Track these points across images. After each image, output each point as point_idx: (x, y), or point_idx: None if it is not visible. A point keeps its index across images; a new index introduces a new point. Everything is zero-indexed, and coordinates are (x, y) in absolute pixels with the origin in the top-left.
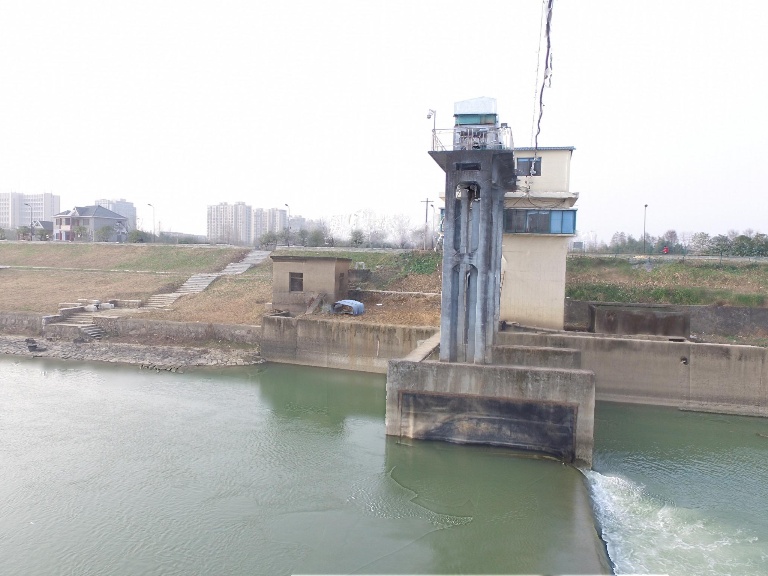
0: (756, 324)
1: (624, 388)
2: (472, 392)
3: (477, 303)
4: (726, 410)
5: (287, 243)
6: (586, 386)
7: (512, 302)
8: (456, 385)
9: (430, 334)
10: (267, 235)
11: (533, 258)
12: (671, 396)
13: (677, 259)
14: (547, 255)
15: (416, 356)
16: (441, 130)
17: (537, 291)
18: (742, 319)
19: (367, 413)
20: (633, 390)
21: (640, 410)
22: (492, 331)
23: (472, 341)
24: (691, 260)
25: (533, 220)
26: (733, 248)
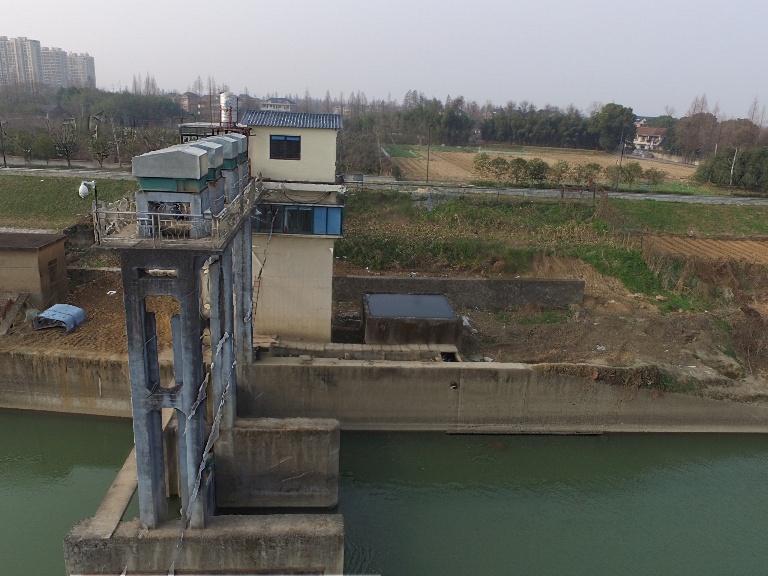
0: (525, 297)
1: (393, 416)
2: (188, 567)
3: (187, 457)
4: (491, 430)
5: (2, 155)
6: (333, 548)
7: (271, 313)
8: (166, 561)
9: (166, 370)
10: None
11: (294, 262)
12: (440, 421)
13: (458, 193)
14: (310, 258)
15: (111, 511)
16: (107, 214)
17: (300, 300)
18: (513, 292)
19: (95, 461)
20: (402, 418)
21: (408, 438)
22: (231, 412)
23: (186, 495)
24: (471, 194)
25: (292, 217)
26: (510, 171)
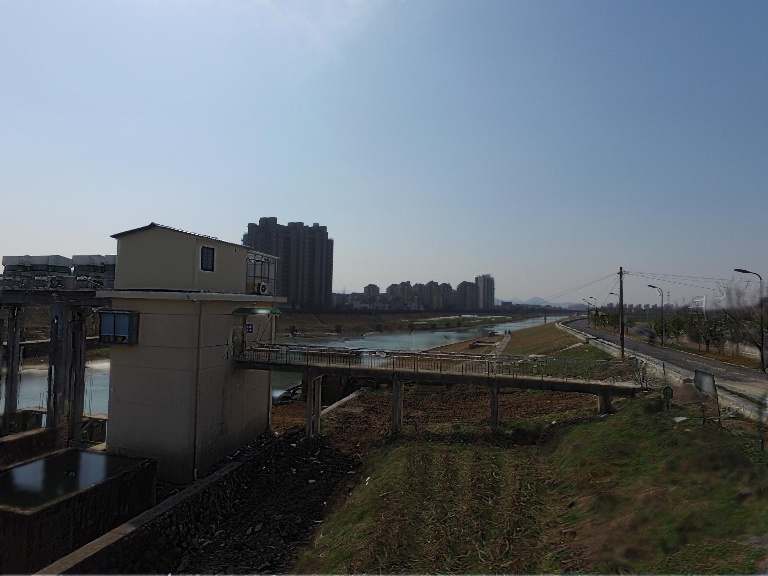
0: None
1: None
2: None
3: None
4: None
5: None
6: None
7: None
8: None
9: None
10: (657, 324)
11: None
12: None
13: None
14: None
15: (34, 408)
16: None
17: None
18: None
19: None
20: None
21: None
22: (47, 414)
23: None
24: None
25: None
26: None
